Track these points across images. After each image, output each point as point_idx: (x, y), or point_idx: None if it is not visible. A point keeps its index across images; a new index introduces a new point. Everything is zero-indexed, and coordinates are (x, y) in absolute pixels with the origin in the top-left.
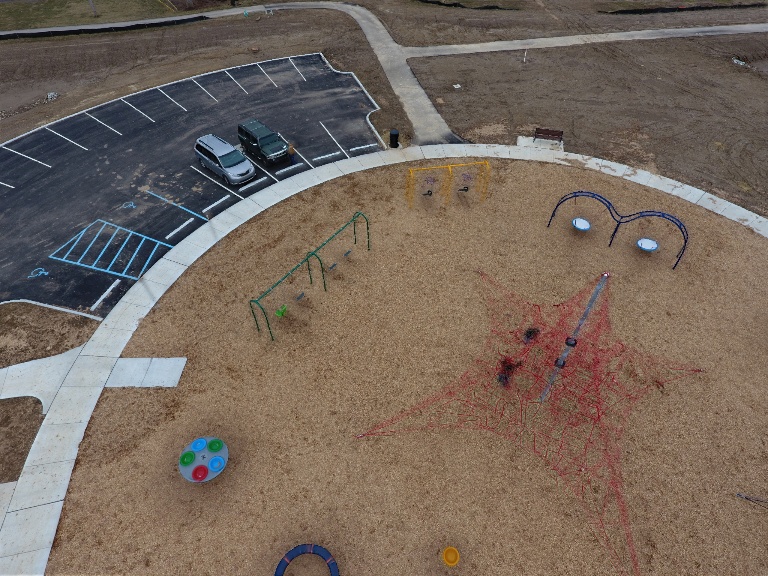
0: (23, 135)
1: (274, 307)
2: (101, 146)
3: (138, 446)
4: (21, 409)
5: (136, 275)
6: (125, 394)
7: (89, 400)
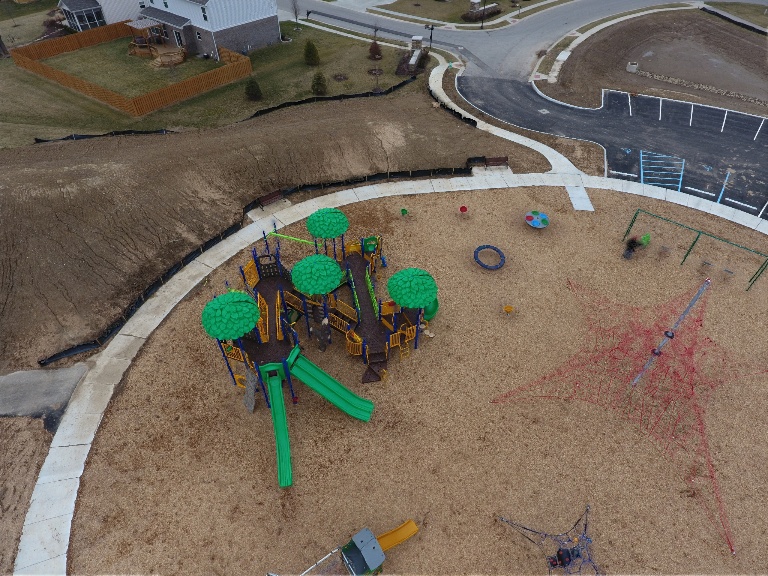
0: (746, 114)
1: (651, 241)
2: (764, 144)
3: (538, 202)
4: (545, 166)
5: (645, 181)
6: (564, 193)
7: (556, 183)
